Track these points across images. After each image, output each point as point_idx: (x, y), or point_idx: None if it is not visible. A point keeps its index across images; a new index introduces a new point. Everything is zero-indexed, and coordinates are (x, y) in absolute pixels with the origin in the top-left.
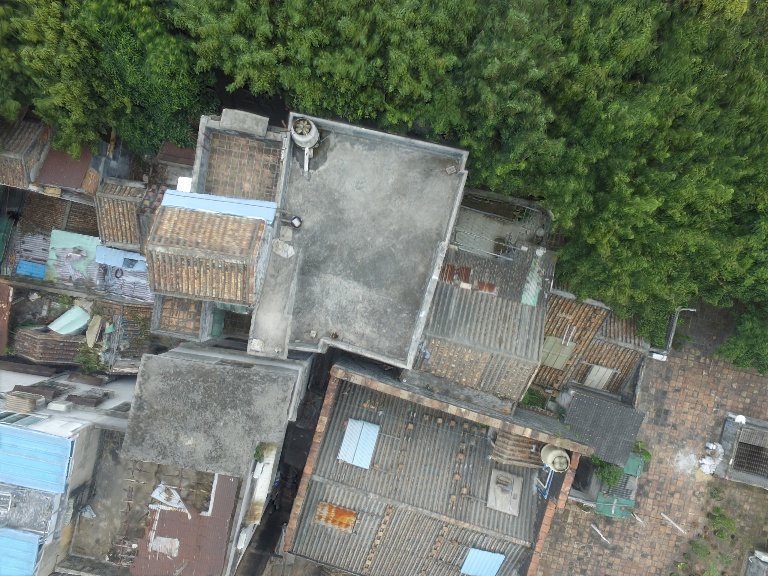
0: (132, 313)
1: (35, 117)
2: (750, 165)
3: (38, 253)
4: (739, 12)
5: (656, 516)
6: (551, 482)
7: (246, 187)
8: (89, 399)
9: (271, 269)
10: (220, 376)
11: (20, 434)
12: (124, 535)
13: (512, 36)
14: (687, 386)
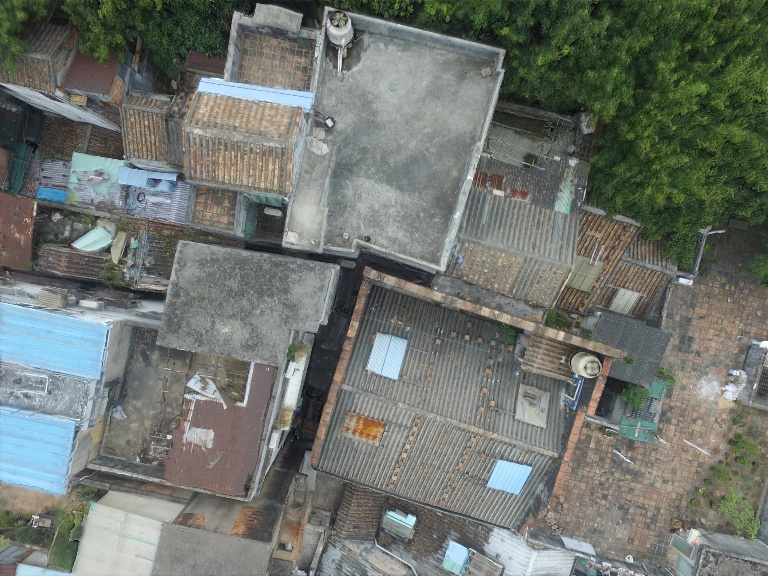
0: (157, 229)
1: (62, 17)
2: None
3: (58, 179)
4: None
5: (678, 442)
6: (580, 393)
7: None
8: (119, 302)
9: (305, 165)
10: (257, 264)
11: (55, 319)
12: (159, 426)
13: None
14: (712, 313)
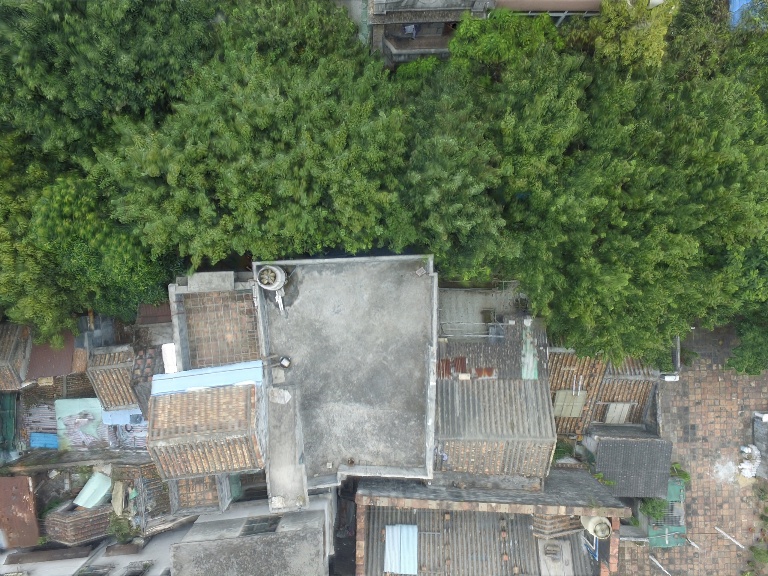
0: (151, 471)
1: None
2: (708, 209)
3: (47, 422)
4: (658, 56)
5: (711, 531)
6: (598, 543)
7: (228, 337)
8: None
9: (272, 420)
10: (250, 548)
11: None
12: None
13: (445, 154)
14: (707, 396)
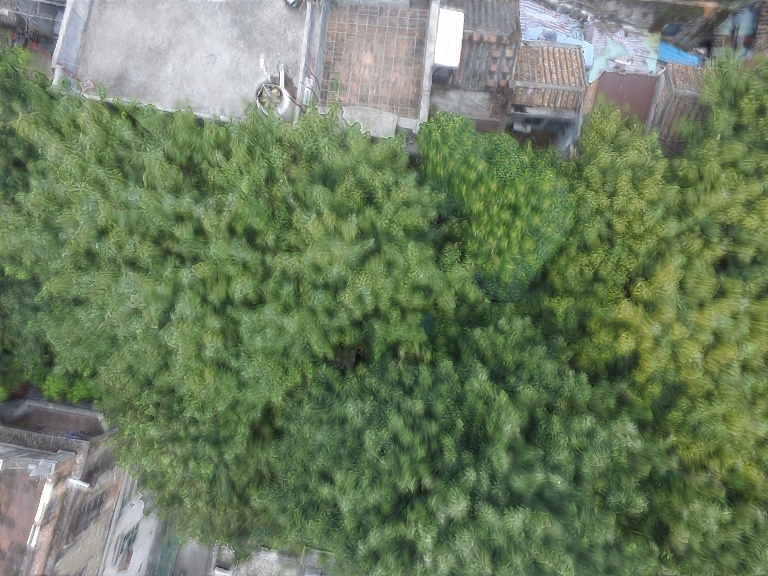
0: None
1: None
2: None
3: None
4: None
5: None
6: None
7: (369, 59)
8: None
9: None
10: None
11: None
12: None
13: None
14: None
